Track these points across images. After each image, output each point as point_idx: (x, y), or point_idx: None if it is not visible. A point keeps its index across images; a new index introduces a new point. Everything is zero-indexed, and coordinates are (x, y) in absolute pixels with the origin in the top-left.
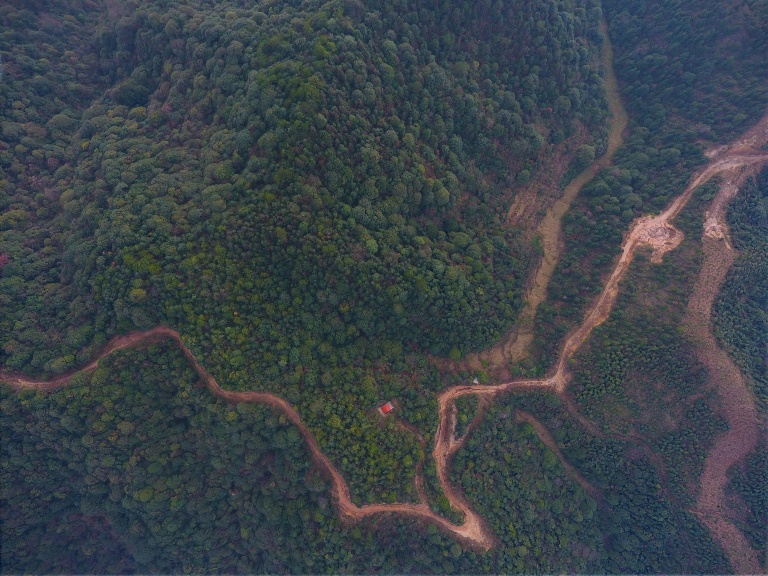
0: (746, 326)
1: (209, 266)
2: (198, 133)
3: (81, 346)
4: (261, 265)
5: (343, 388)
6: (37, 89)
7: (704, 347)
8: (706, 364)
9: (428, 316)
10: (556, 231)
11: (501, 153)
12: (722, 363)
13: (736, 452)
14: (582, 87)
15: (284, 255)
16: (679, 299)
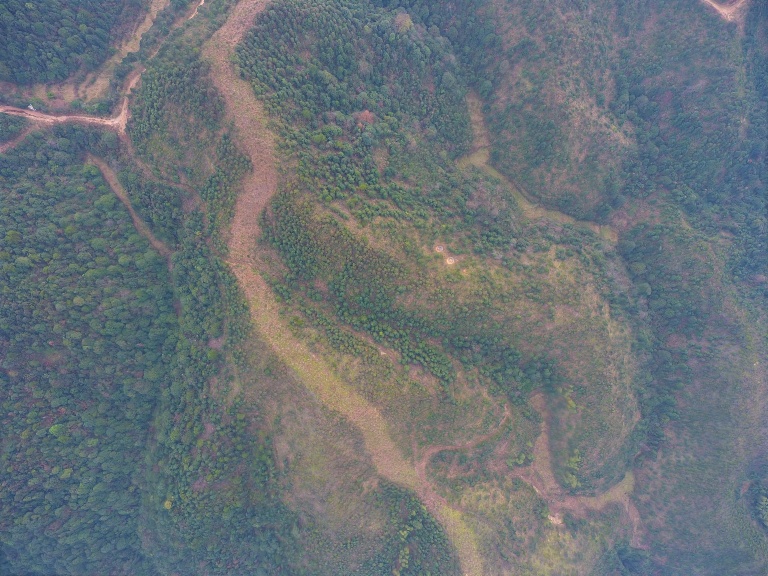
0: (297, 77)
1: None
2: None
3: None
4: None
5: None
6: None
7: (218, 70)
8: (220, 89)
9: None
10: None
11: None
12: (236, 90)
13: (263, 197)
14: None
15: None
16: (208, 25)
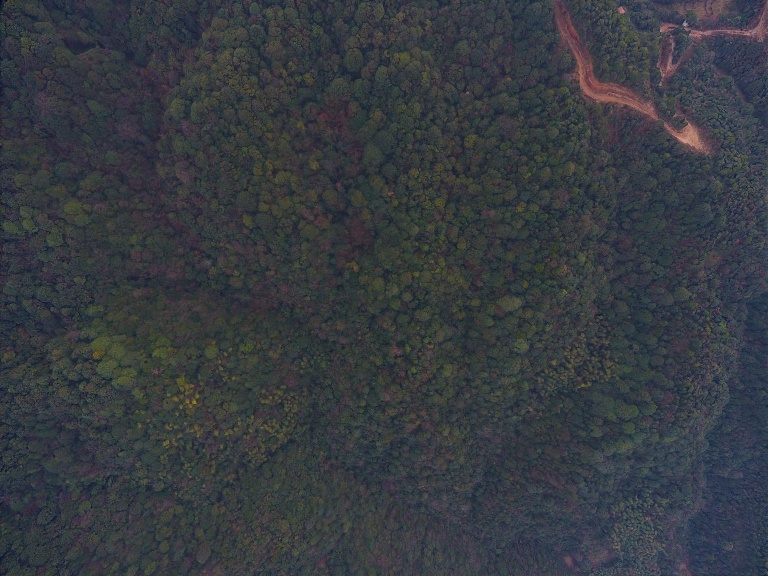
0: None
1: None
2: None
3: None
4: None
5: None
6: None
7: None
8: None
9: None
10: None
11: None
12: None
13: None
14: None
15: None
16: None
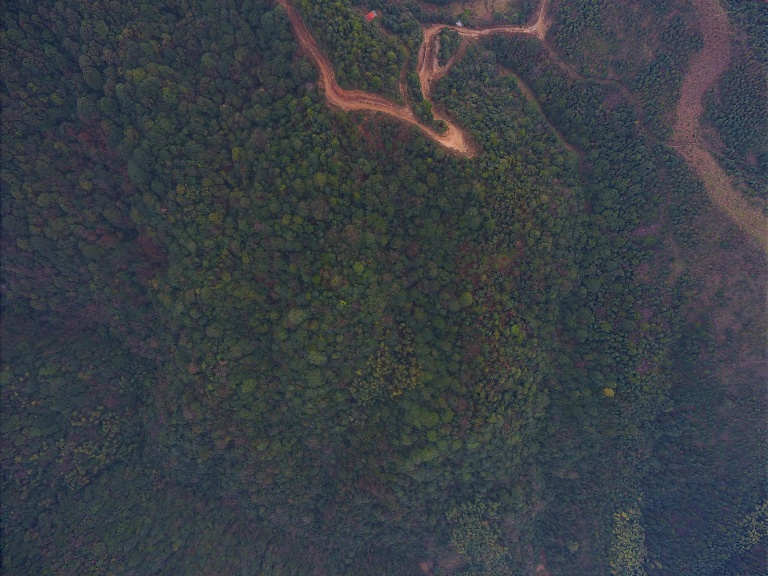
0: None
1: None
2: None
3: None
4: None
5: None
6: None
7: None
8: None
9: None
10: None
11: None
12: None
13: (710, 75)
14: None
15: None
16: None
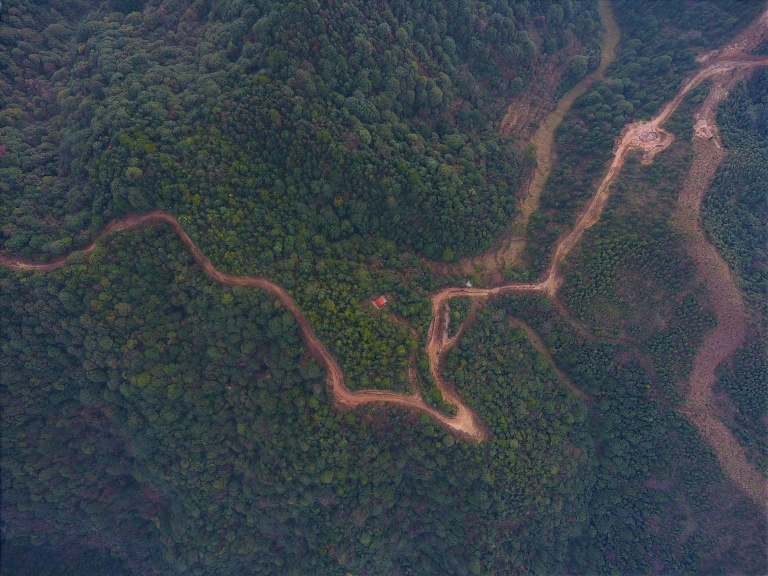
0: (735, 227)
1: (204, 147)
2: (193, 33)
3: (78, 229)
4: (256, 150)
5: (337, 277)
6: None
7: (693, 240)
8: (695, 258)
9: (421, 214)
10: (549, 143)
11: (494, 59)
12: (711, 256)
13: (724, 349)
14: None
15: (278, 141)
16: (669, 195)
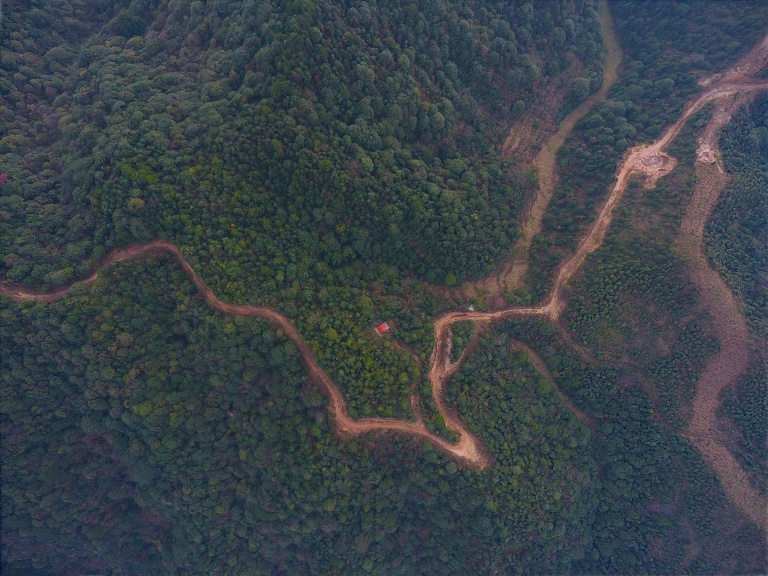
0: (738, 251)
1: (206, 177)
2: (195, 59)
3: (80, 259)
4: (258, 179)
5: (339, 305)
6: (35, 22)
7: (696, 267)
8: (698, 284)
9: (424, 239)
10: (551, 165)
11: (496, 82)
12: (714, 283)
13: (728, 374)
14: (577, 20)
15: (280, 170)
16: (672, 221)
